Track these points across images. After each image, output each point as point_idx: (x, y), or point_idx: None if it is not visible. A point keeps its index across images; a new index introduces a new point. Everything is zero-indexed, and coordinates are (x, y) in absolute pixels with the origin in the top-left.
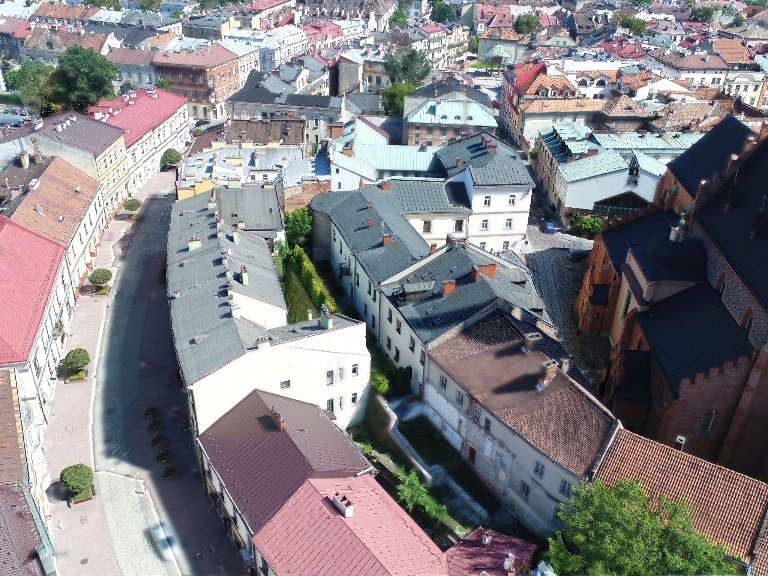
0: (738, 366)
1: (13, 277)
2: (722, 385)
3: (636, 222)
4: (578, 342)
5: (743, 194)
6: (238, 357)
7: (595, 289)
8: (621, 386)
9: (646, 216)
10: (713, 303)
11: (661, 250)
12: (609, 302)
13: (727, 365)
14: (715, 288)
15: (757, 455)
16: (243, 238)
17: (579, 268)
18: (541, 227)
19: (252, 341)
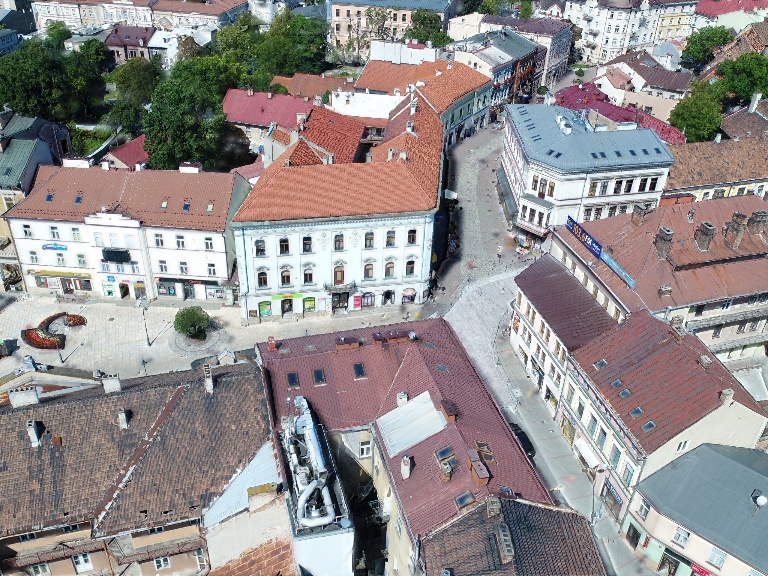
0: None
1: (749, 7)
2: None
3: None
4: None
5: None
6: (733, 11)
7: None
8: None
9: None
10: None
11: None
12: None
13: None
14: None
15: None
16: None
17: None
18: None
19: None
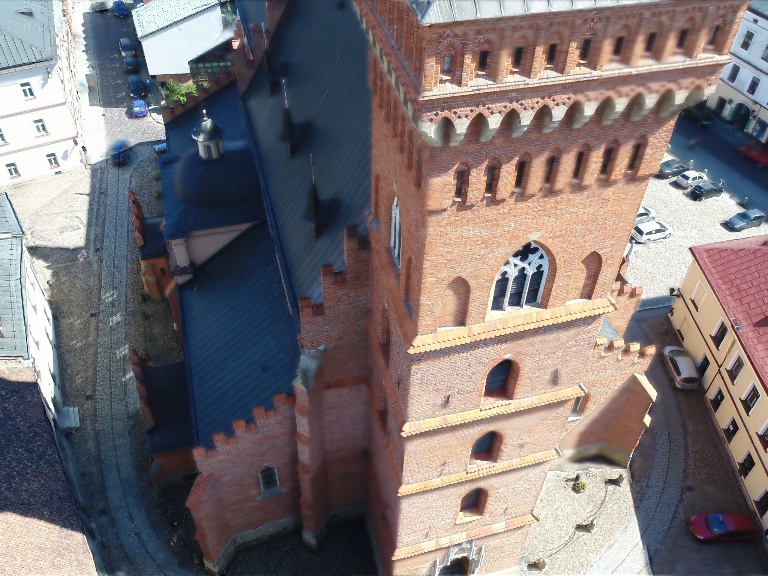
0: (274, 409)
1: None
2: (262, 438)
3: (208, 102)
4: (141, 318)
5: (286, 63)
6: None
7: (150, 231)
8: (156, 425)
9: (221, 90)
10: (268, 263)
11: (186, 178)
12: (168, 251)
13: (254, 415)
14: (271, 234)
15: (361, 493)
16: None
17: None
18: (129, 109)
19: None
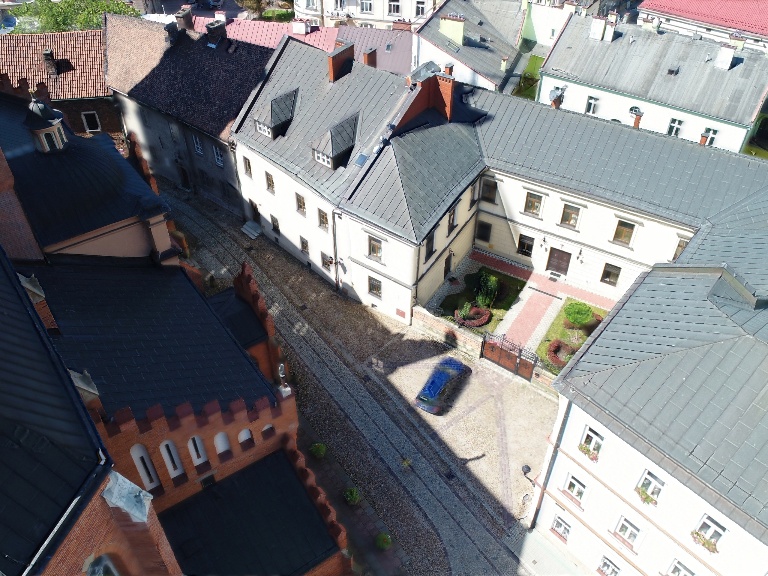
0: None
1: None
2: None
3: None
4: None
5: None
6: None
7: (239, 306)
8: None
9: None
10: None
11: None
12: None
13: None
14: None
15: None
16: (743, 84)
17: (371, 561)
18: None
19: (485, 11)
